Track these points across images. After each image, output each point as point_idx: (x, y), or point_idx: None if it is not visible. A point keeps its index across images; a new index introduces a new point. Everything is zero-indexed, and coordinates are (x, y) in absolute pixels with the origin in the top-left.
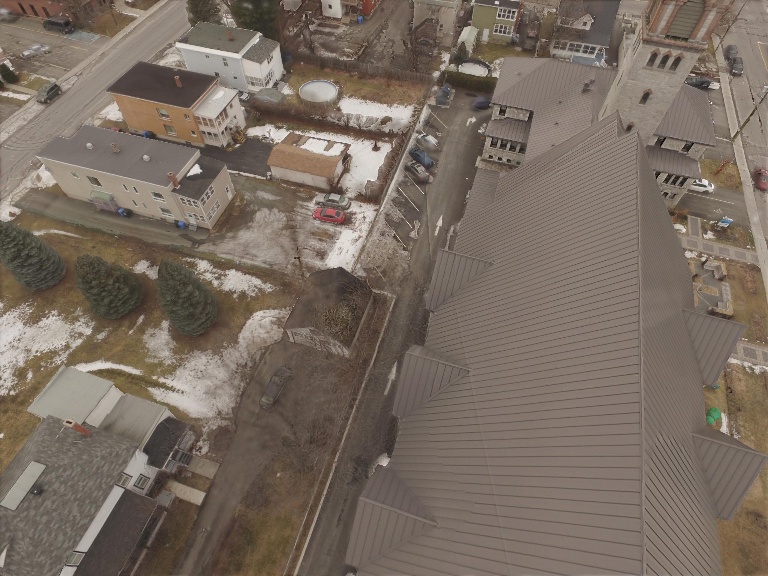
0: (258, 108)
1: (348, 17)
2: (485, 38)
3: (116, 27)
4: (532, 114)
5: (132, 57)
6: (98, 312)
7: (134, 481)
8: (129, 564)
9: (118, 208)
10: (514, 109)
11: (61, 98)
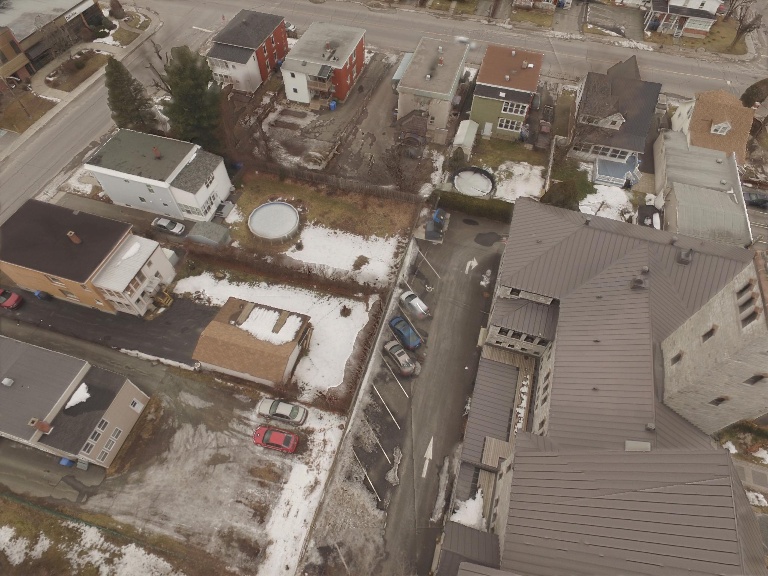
0: (192, 251)
1: (318, 102)
2: (487, 132)
3: (28, 118)
4: None
5: (43, 164)
6: None
7: None
8: None
9: None
10: None
11: None
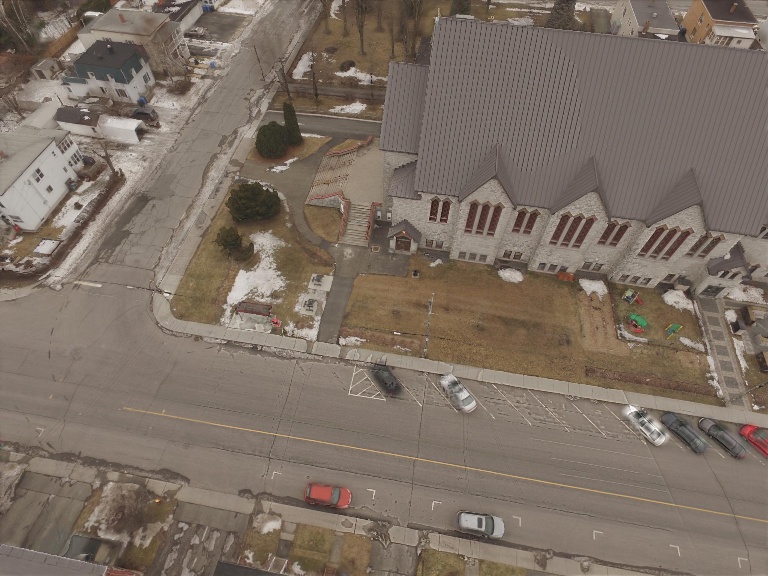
0: None
1: None
2: None
3: None
4: None
5: (752, 8)
6: None
7: None
8: None
9: None
10: None
11: None
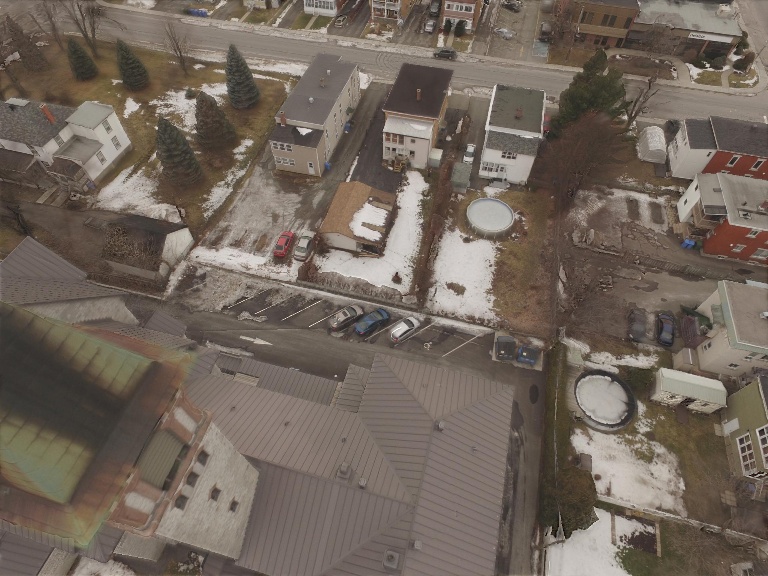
0: None
1: None
2: (728, 429)
3: (565, 61)
4: None
5: (520, 81)
6: None
7: (42, 160)
8: (6, 174)
9: None
10: None
11: (446, 61)
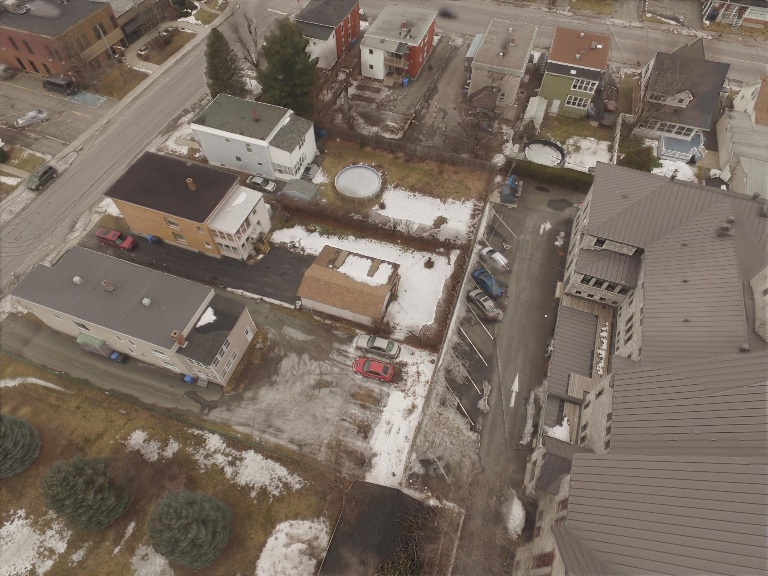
0: (286, 205)
1: (391, 79)
2: (554, 109)
3: (125, 87)
4: (640, 250)
5: (141, 127)
6: (75, 525)
7: None
8: None
9: (111, 352)
10: (617, 242)
11: (56, 182)
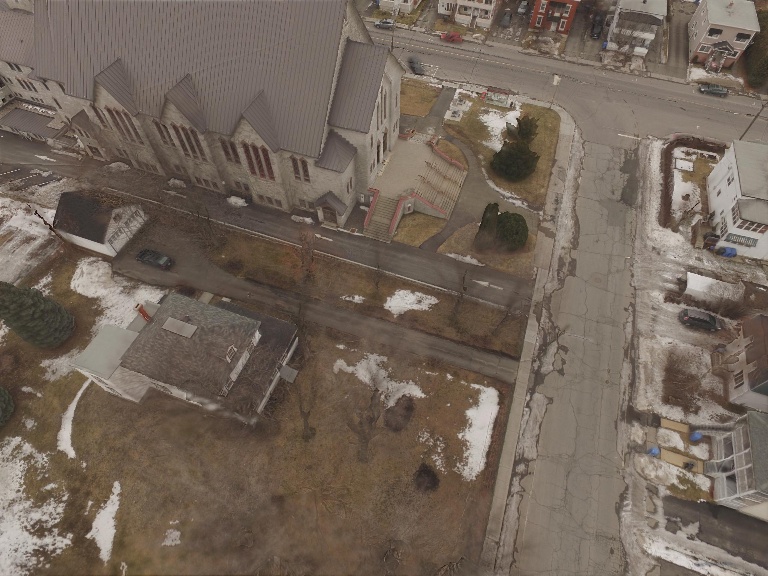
0: None
1: None
2: None
3: None
4: None
5: None
6: None
7: None
8: None
9: None
10: None
11: None
